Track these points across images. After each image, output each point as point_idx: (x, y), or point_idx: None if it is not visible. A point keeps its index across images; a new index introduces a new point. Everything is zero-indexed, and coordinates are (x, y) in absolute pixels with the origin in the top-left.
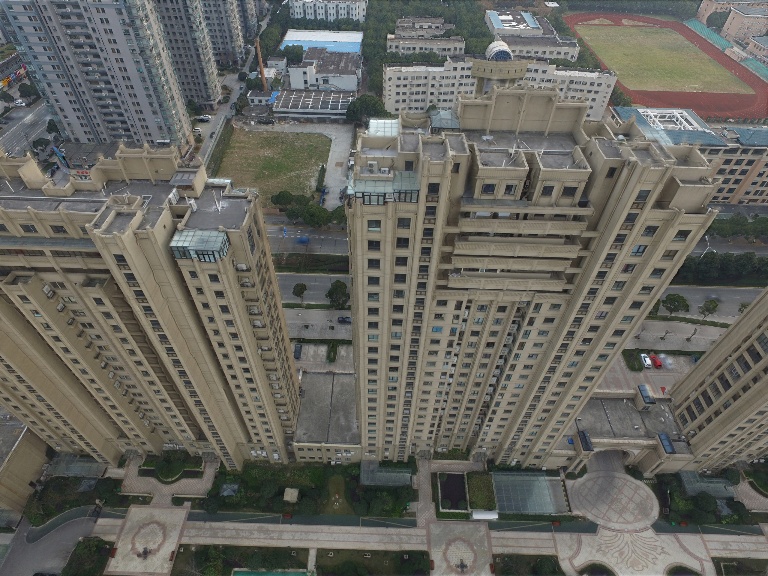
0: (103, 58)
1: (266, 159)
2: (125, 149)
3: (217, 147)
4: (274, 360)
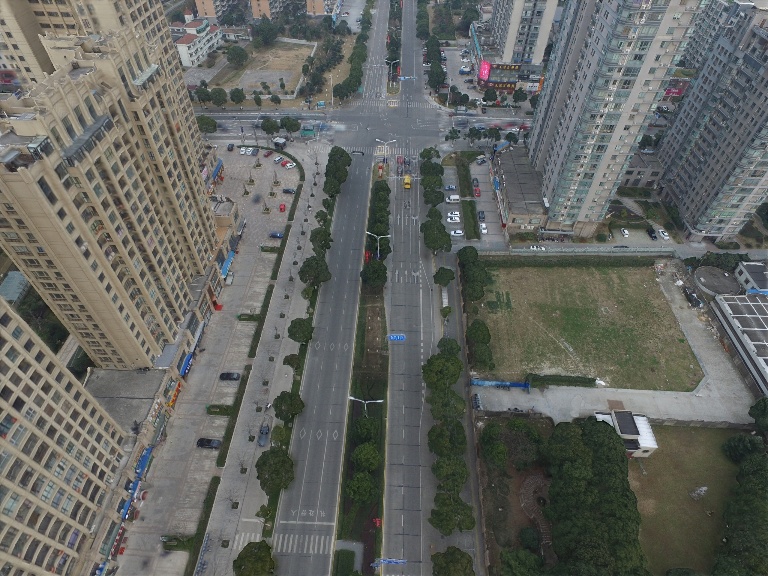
0: (572, 98)
1: (590, 310)
2: (67, 80)
3: (597, 257)
4: (39, 289)
